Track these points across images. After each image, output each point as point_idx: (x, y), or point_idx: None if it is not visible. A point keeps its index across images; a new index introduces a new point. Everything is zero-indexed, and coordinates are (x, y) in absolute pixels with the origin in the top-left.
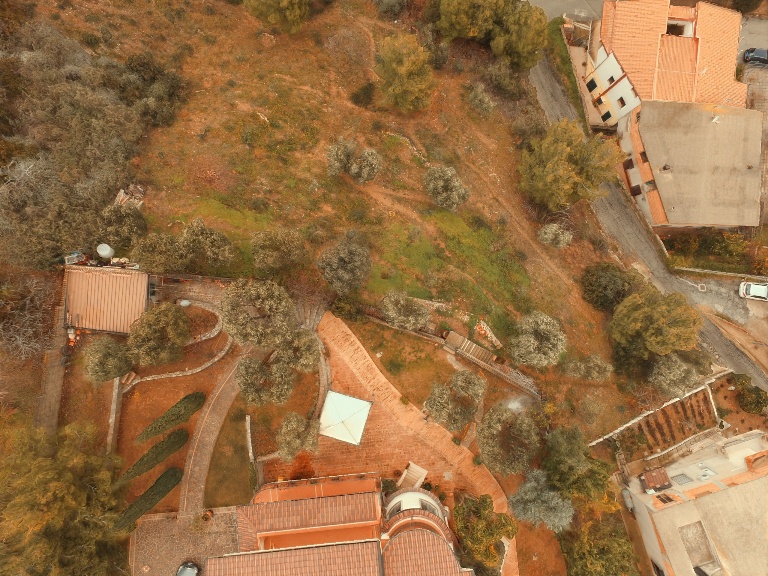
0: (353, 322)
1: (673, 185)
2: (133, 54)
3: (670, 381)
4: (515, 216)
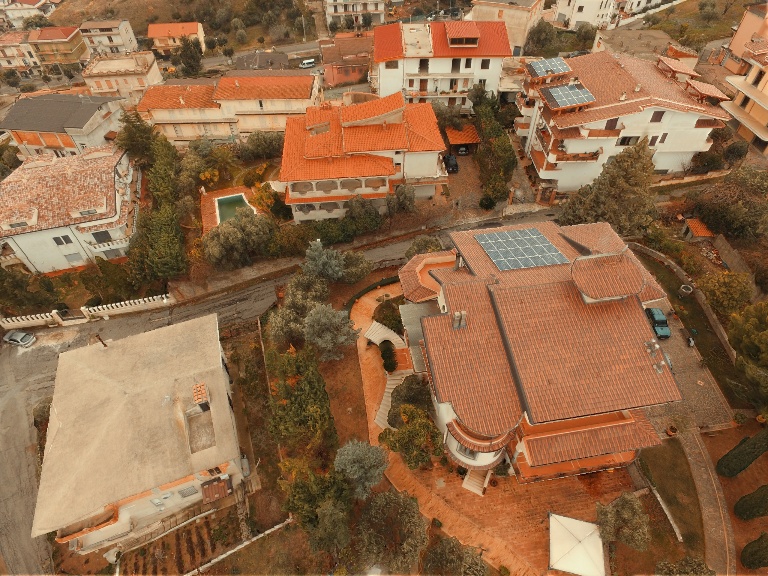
0: None
1: None
2: None
3: None
4: None
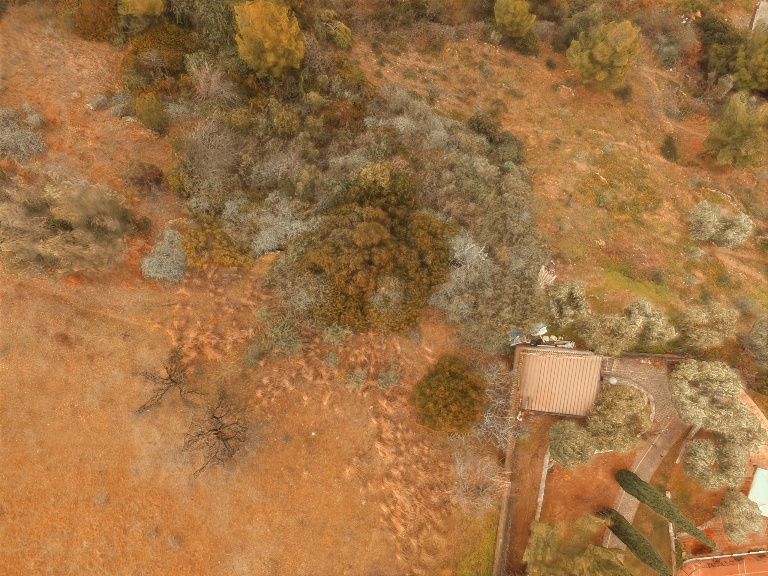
0: (756, 394)
1: None
2: (453, 111)
3: None
4: None
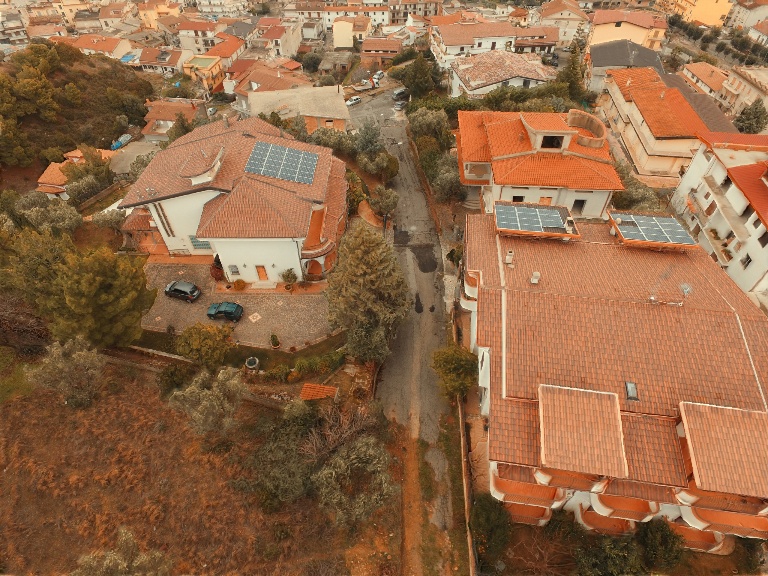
0: None
1: None
2: None
3: None
4: None
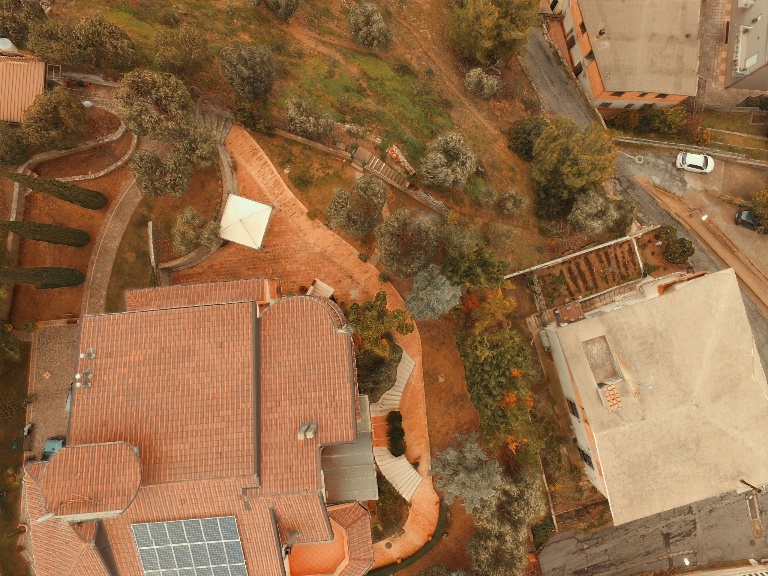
0: (261, 137)
1: (610, 52)
2: None
3: (587, 217)
4: (445, 71)
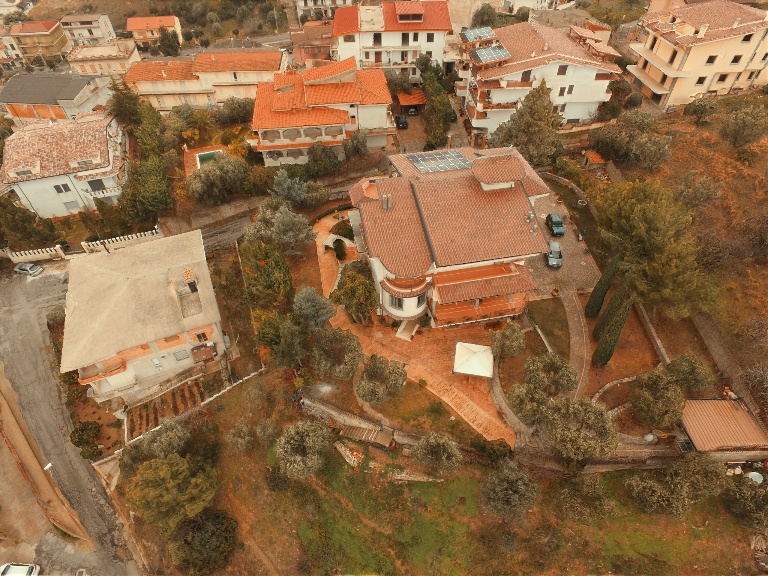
0: None
1: None
2: None
3: None
4: None
